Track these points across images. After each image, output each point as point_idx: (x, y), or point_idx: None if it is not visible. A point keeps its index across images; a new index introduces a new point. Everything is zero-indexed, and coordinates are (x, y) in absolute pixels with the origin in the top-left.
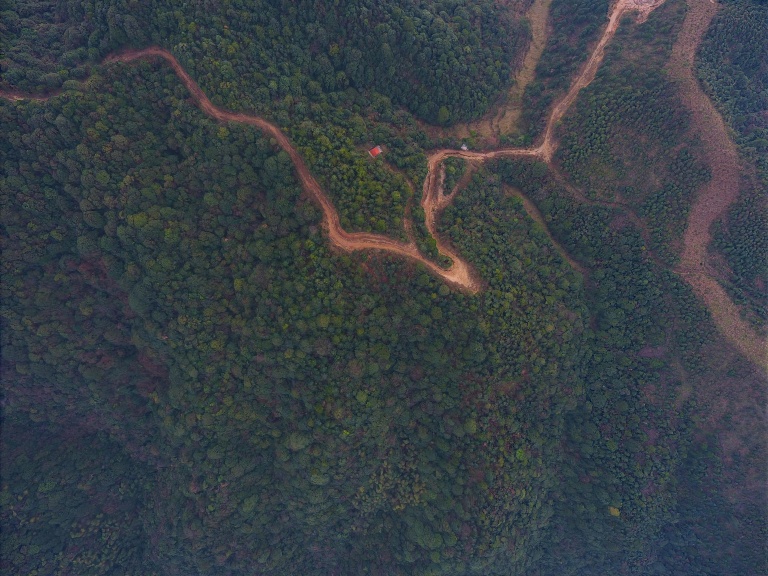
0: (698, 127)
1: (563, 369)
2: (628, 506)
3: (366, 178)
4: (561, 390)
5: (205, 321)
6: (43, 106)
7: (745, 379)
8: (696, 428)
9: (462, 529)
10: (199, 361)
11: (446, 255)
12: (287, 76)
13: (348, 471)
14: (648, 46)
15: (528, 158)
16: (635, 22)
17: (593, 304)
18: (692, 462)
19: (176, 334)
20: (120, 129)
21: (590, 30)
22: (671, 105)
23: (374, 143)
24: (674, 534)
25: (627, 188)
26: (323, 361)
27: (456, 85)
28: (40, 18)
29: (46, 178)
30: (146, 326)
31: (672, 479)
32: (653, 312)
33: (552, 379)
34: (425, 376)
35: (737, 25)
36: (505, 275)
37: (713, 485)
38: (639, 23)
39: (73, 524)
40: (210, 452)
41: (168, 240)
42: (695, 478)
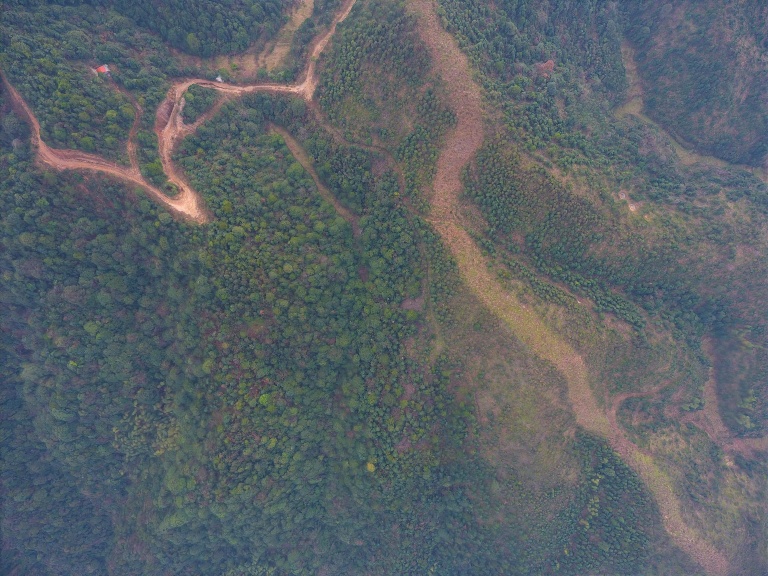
0: (439, 66)
1: (319, 316)
2: (380, 461)
3: (68, 91)
4: (318, 338)
5: None
6: None
7: (491, 334)
8: (455, 386)
9: (198, 472)
10: None
11: (177, 184)
12: None
13: (91, 407)
14: None
15: (288, 95)
16: None
17: (360, 253)
18: (452, 421)
19: None
20: None
21: None
22: (411, 41)
23: (99, 61)
24: (448, 498)
25: (381, 130)
26: (41, 285)
27: (205, 11)
28: None
29: None
30: None
31: (433, 438)
32: (411, 262)
33: (304, 325)
34: (170, 313)
35: None
36: (237, 208)
37: (473, 446)
38: None
39: None
40: None
41: None
42: (456, 438)
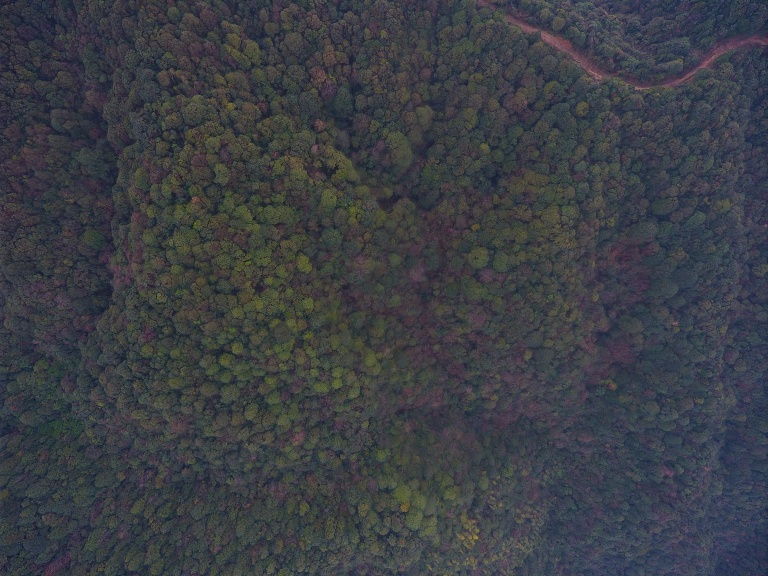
0: None
1: None
2: None
3: None
4: None
5: (725, 306)
6: (676, 94)
7: None
8: None
9: None
10: (704, 346)
11: None
12: None
13: None
14: None
15: None
16: None
17: None
18: None
19: (692, 319)
20: (736, 116)
21: None
22: None
23: None
24: None
25: None
26: None
27: None
28: (603, 9)
29: (640, 165)
30: (662, 312)
31: None
32: None
33: None
34: None
35: None
36: None
37: None
38: None
39: (518, 510)
40: (700, 436)
41: (739, 225)
42: None
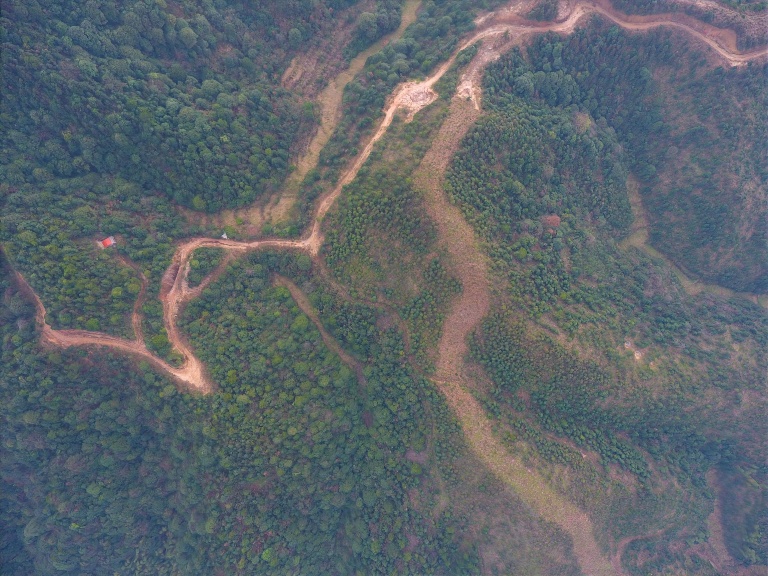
0: (445, 239)
1: (322, 468)
2: None
3: (74, 276)
4: (321, 489)
5: None
6: None
7: (496, 496)
8: (459, 537)
9: None
10: None
11: (182, 351)
12: (3, 164)
13: (92, 559)
14: (407, 149)
15: (294, 250)
16: (403, 121)
17: (364, 400)
18: (456, 570)
19: None
20: None
21: (363, 124)
22: (418, 214)
23: (105, 234)
24: None
25: (387, 290)
26: (43, 454)
27: (212, 174)
28: None
29: None
30: None
31: None
32: (416, 416)
33: (308, 478)
34: (173, 468)
35: (504, 132)
36: (242, 376)
37: None
38: (407, 122)
39: None
40: None
41: None
42: None
